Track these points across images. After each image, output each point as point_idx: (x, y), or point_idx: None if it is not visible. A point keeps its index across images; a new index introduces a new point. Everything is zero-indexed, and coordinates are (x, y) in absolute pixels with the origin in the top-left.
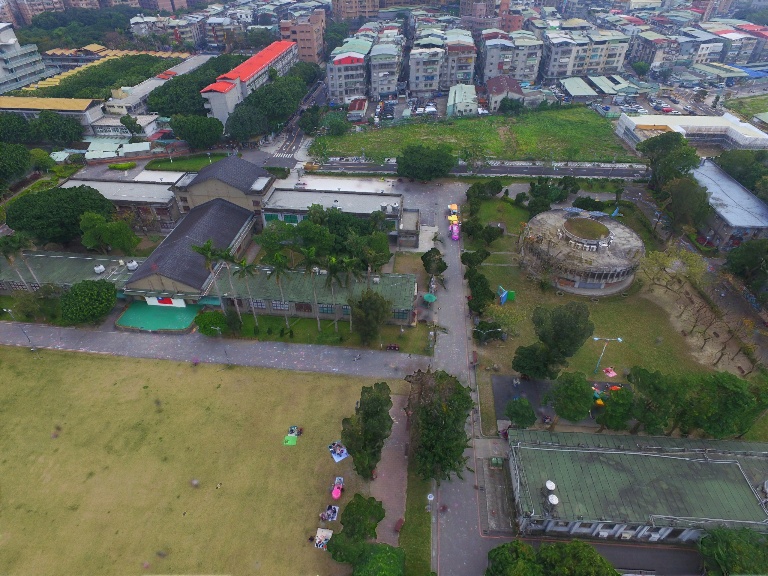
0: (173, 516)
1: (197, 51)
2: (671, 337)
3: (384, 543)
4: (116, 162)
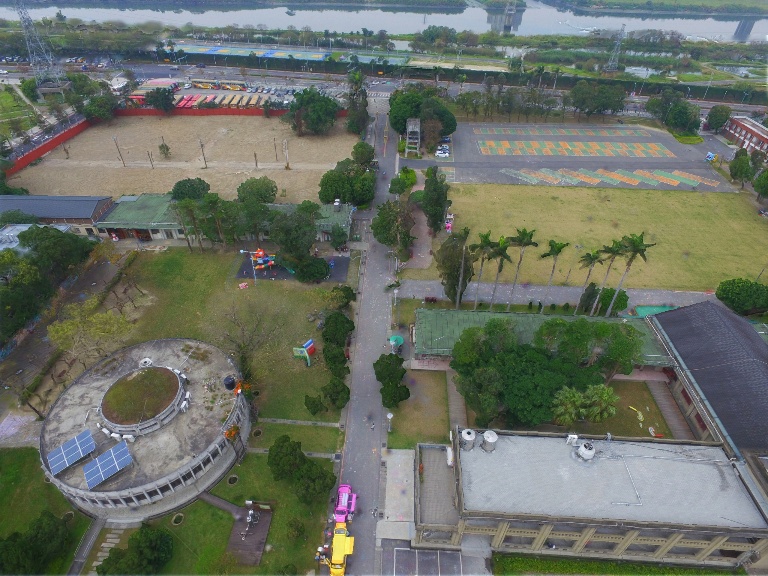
0: None
1: None
2: (153, 318)
3: (420, 201)
4: None
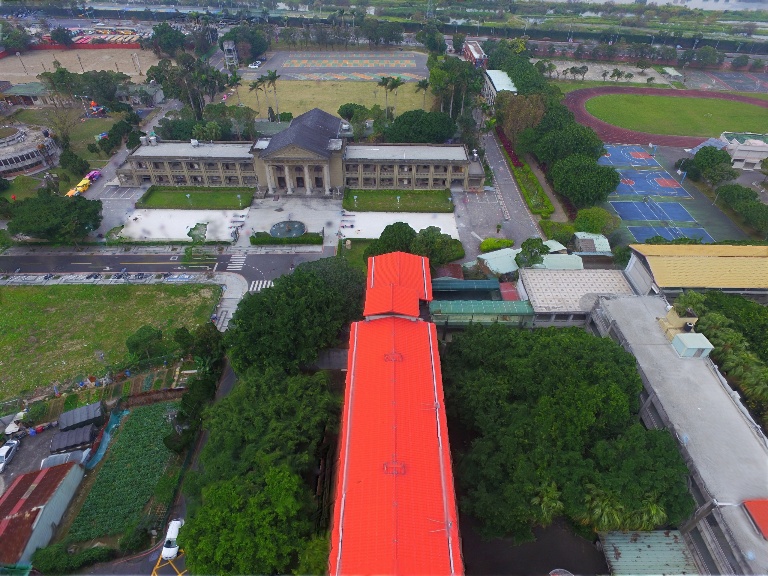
0: (280, 94)
1: None
2: None
3: None
4: None
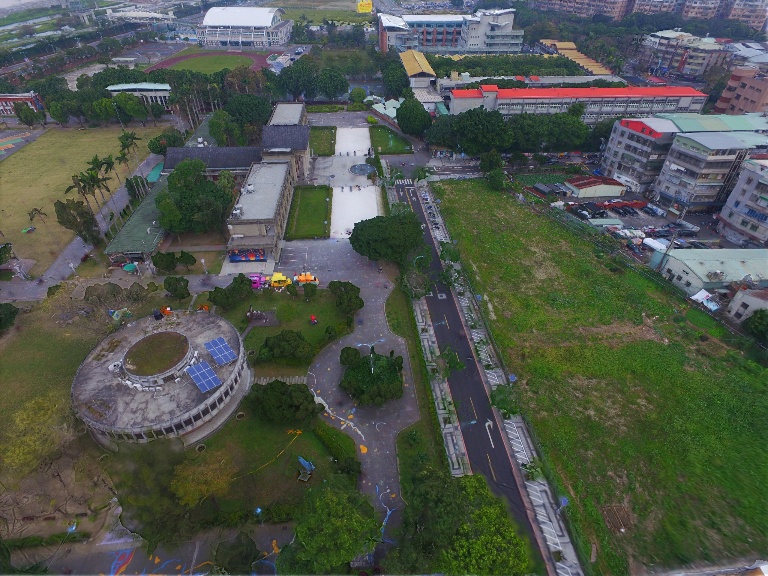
0: (4, 208)
1: (622, 72)
2: None
3: None
4: (380, 117)
